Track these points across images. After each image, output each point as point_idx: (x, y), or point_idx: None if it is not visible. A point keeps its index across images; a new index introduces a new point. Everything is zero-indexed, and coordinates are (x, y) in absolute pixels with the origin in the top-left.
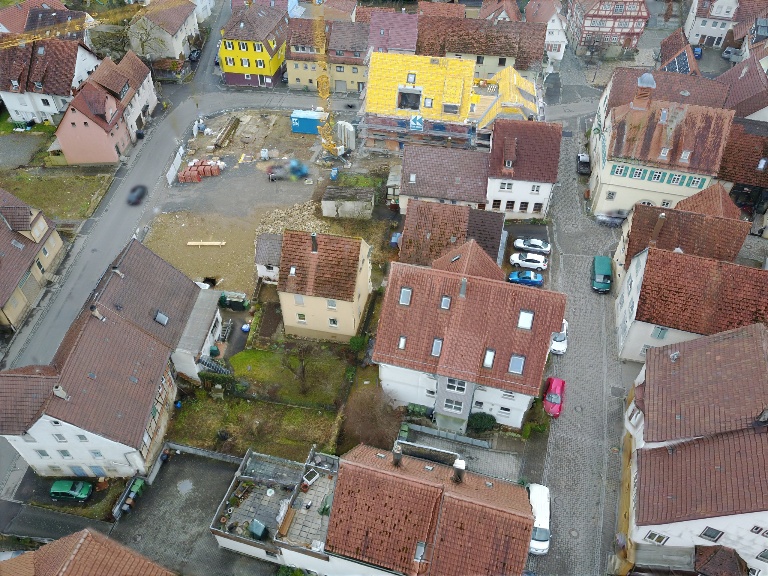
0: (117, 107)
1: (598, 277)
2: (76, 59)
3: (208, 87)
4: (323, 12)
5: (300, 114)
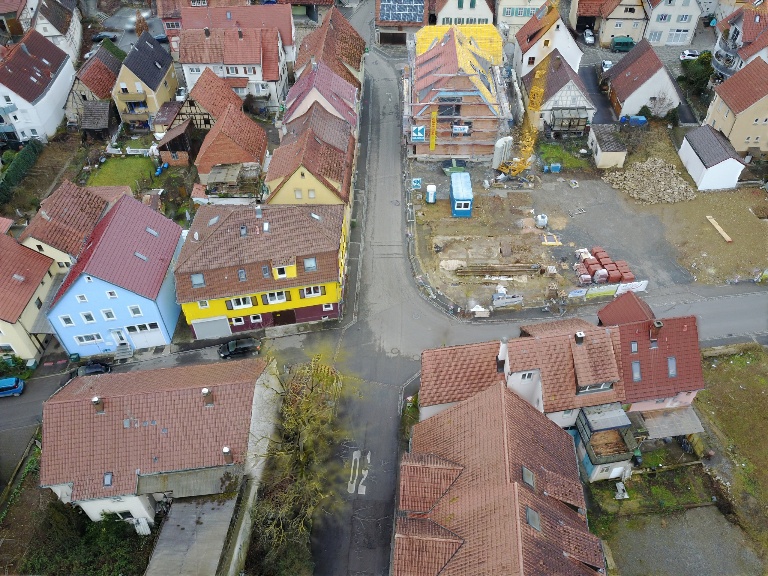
0: None
1: (634, 43)
2: None
3: (353, 339)
4: None
5: (464, 192)
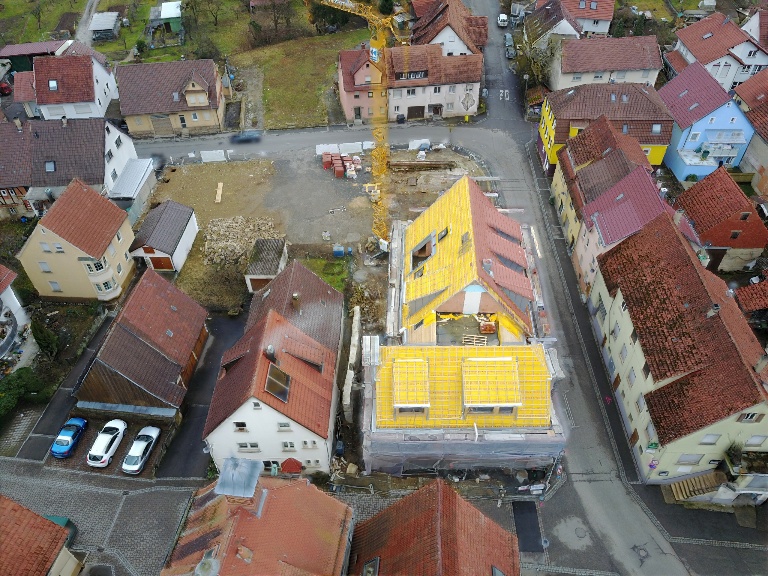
0: (384, 81)
1: None
2: (439, 35)
3: (524, 135)
4: (767, 163)
5: None
